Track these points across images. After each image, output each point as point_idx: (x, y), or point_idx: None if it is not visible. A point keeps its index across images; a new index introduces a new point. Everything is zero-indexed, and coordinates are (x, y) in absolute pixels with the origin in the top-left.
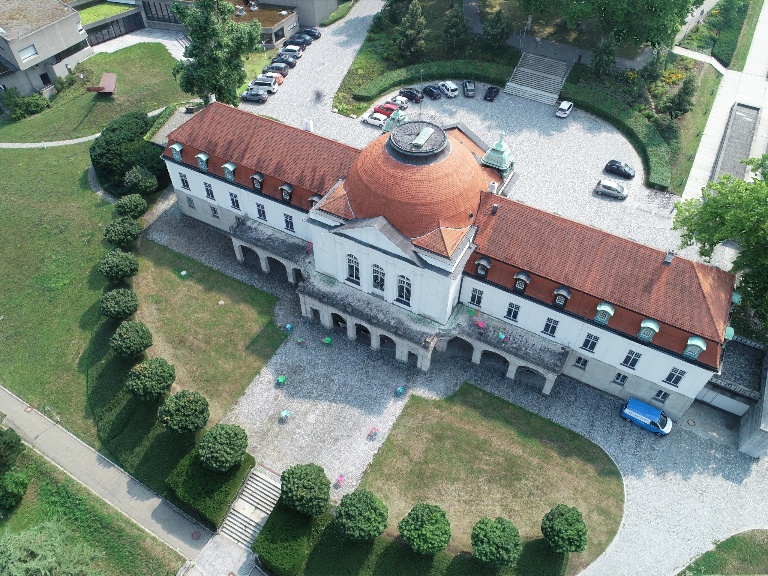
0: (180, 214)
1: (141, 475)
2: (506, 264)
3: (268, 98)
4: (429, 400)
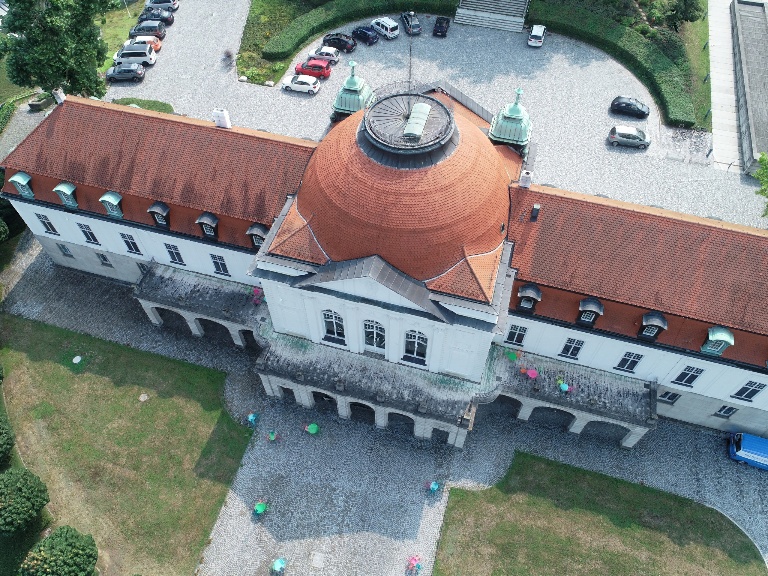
0: (53, 266)
1: None
2: (564, 290)
3: (145, 73)
4: (477, 492)
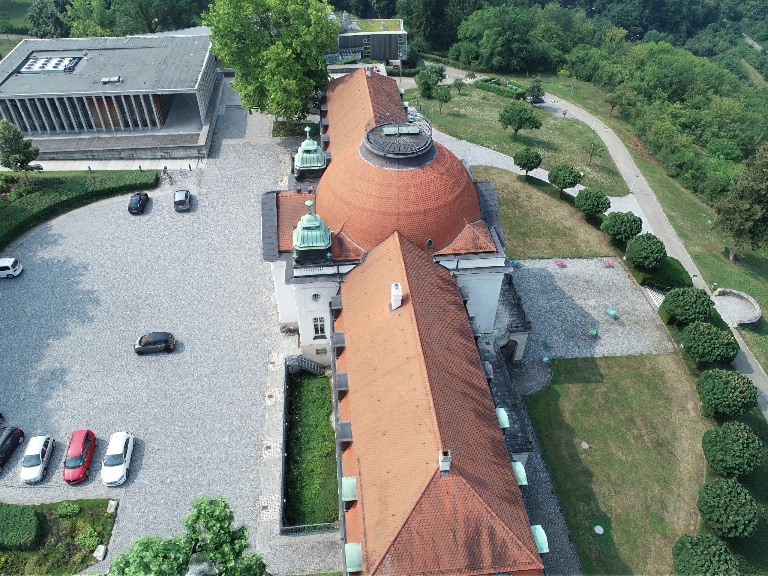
0: None
1: None
2: None
3: None
4: None
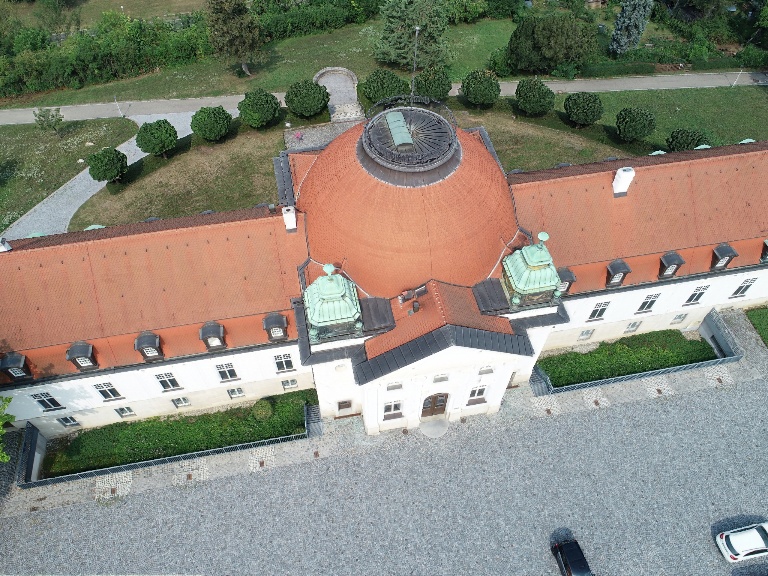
0: None
1: None
2: None
3: None
4: None
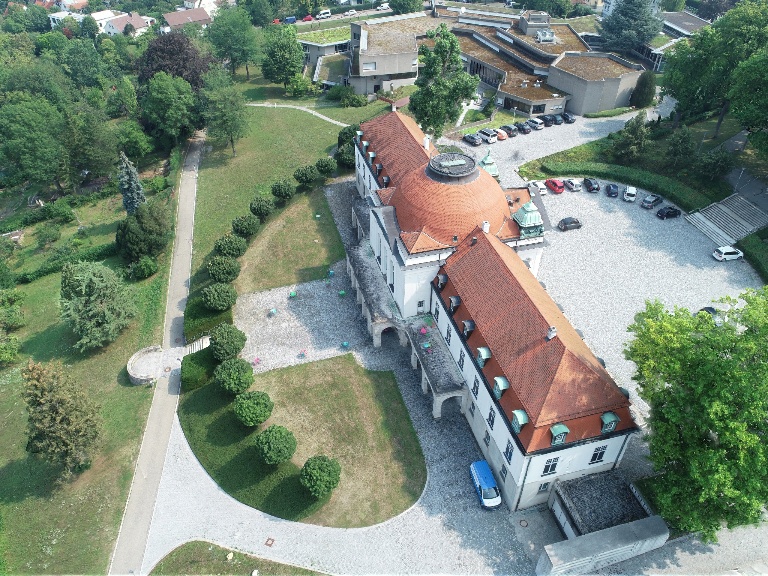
0: (354, 186)
1: (190, 297)
2: (453, 286)
3: (482, 145)
4: (356, 363)
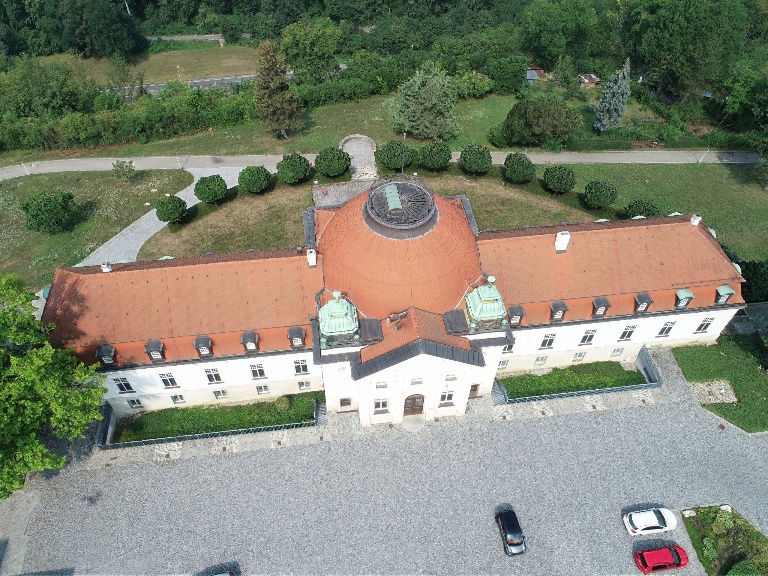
0: None
1: None
2: None
3: None
4: None
